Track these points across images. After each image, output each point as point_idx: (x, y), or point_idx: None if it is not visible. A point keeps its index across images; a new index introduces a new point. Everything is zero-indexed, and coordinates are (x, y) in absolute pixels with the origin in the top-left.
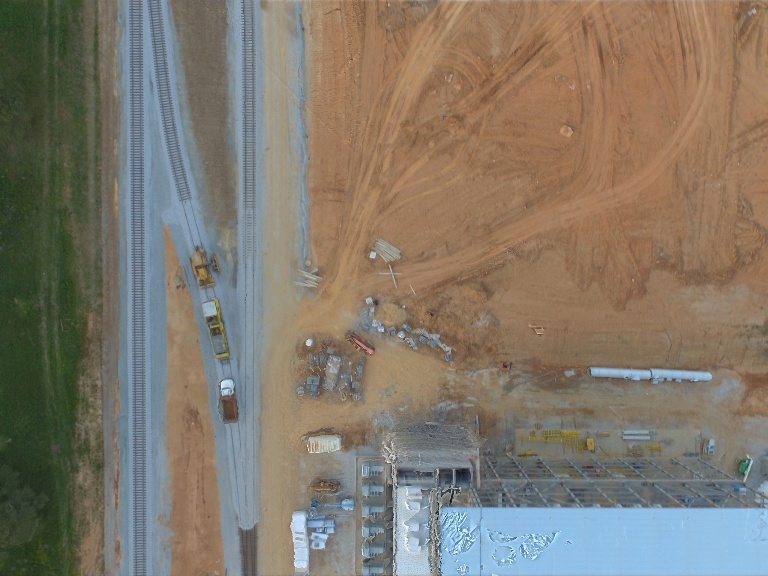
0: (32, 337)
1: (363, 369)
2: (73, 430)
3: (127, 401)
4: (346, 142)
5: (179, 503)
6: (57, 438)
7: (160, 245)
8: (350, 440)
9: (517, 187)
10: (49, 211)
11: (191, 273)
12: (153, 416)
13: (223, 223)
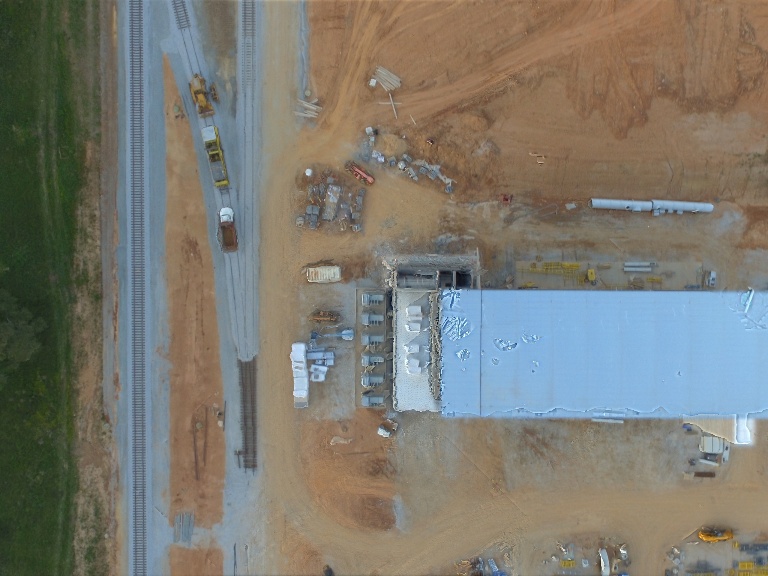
0: (30, 165)
1: (363, 200)
2: (71, 260)
3: (126, 231)
4: None
5: (178, 335)
6: (55, 268)
7: (159, 74)
8: (350, 272)
9: (518, 13)
10: (47, 36)
11: (190, 101)
12: (152, 247)
13: (222, 52)
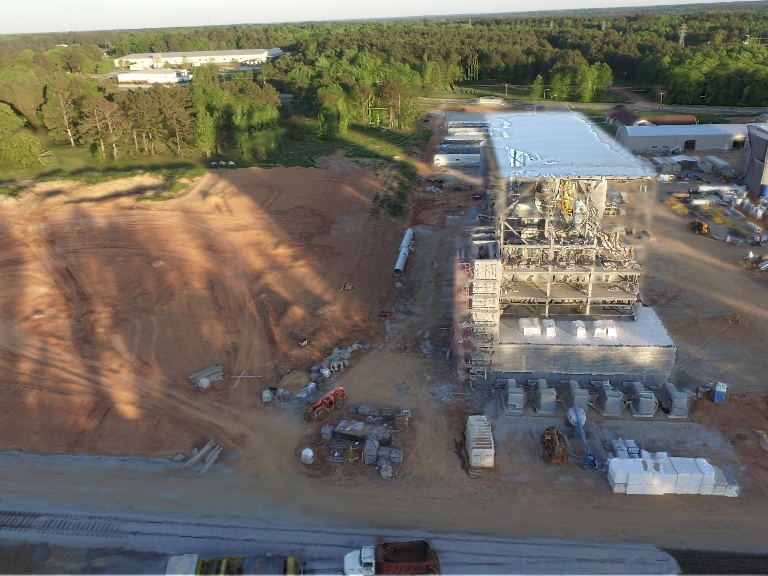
0: None
1: None
2: None
3: None
4: (33, 397)
5: None
6: None
7: None
8: None
9: (192, 293)
10: None
11: None
12: None
13: (28, 572)
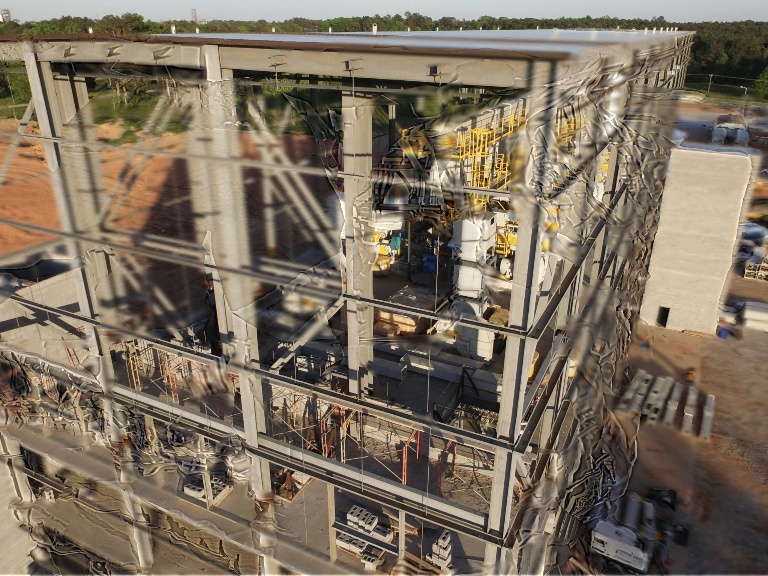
0: None
1: None
2: None
3: None
4: None
5: None
6: None
7: None
8: None
9: None
10: None
11: None
12: None
13: None
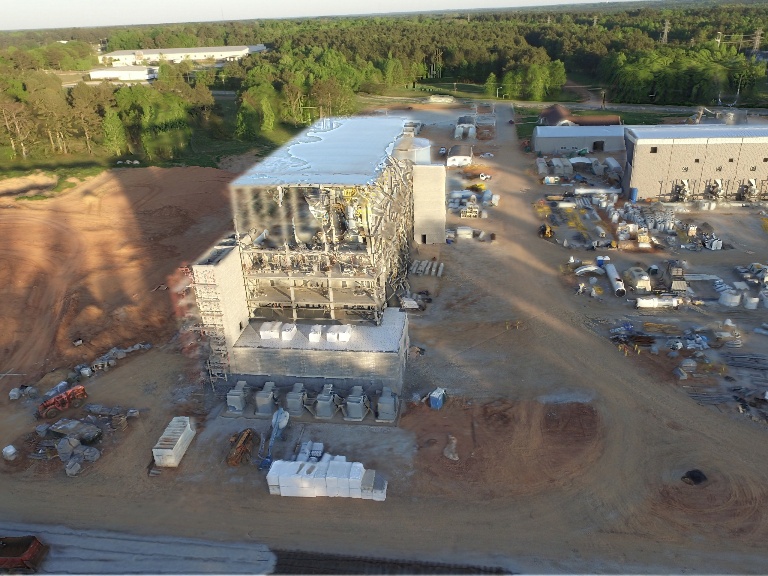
0: None
1: None
2: None
3: None
4: None
5: None
6: None
7: None
8: None
9: (10, 292)
10: None
11: None
12: None
13: None
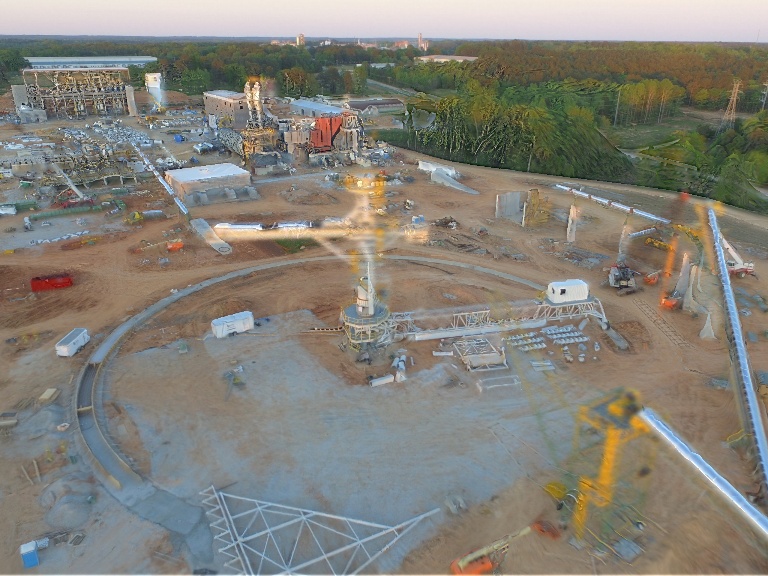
0: None
1: None
2: None
3: None
4: None
5: None
6: None
7: None
8: None
9: None
10: None
11: None
12: None
13: None
